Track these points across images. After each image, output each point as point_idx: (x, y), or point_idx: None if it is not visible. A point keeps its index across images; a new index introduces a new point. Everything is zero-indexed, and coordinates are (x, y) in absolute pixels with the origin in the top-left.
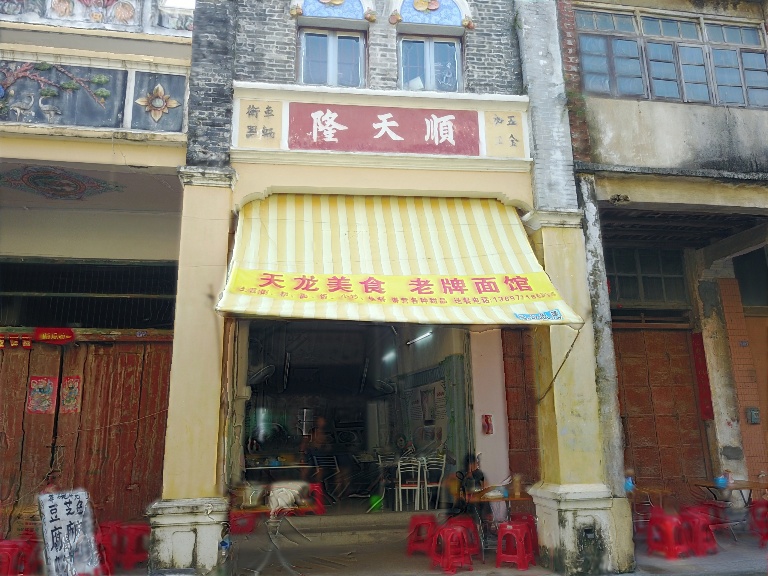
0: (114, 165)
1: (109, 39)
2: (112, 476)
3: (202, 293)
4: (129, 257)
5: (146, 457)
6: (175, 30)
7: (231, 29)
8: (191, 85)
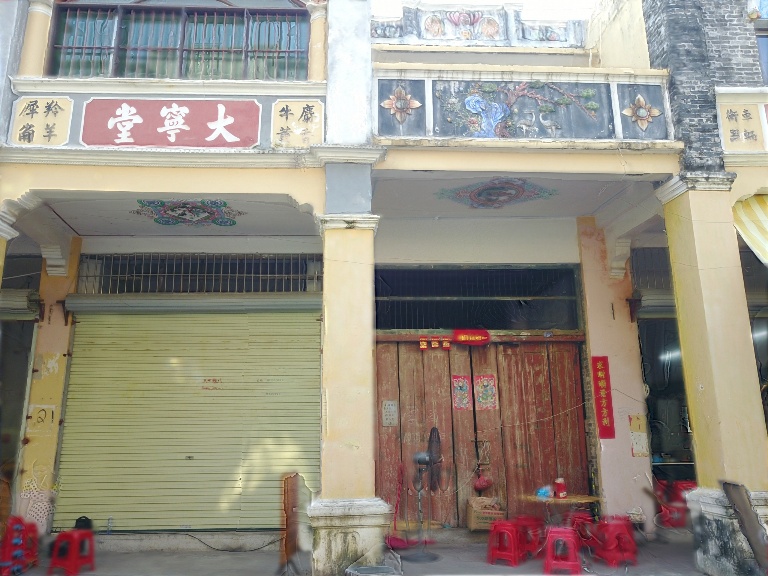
0: (612, 174)
1: (498, 55)
2: (540, 470)
3: (725, 294)
4: (529, 261)
5: (566, 452)
6: (539, 41)
7: (704, 37)
8: (678, 94)
